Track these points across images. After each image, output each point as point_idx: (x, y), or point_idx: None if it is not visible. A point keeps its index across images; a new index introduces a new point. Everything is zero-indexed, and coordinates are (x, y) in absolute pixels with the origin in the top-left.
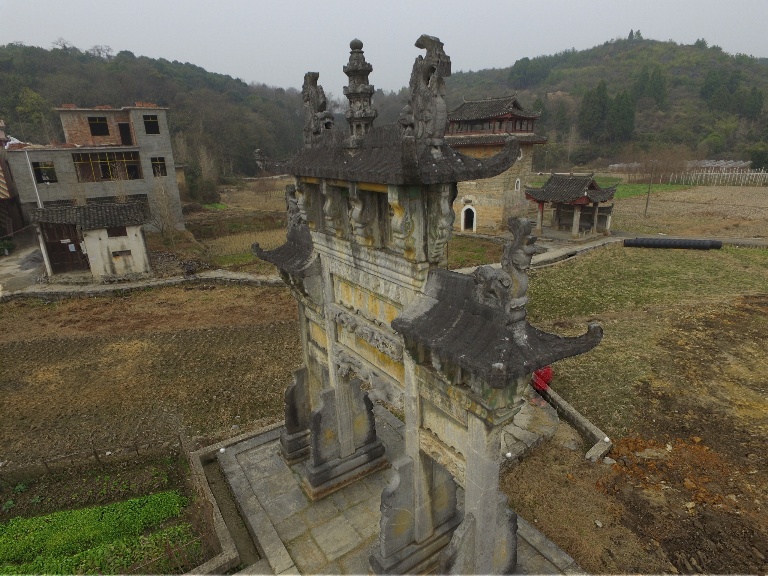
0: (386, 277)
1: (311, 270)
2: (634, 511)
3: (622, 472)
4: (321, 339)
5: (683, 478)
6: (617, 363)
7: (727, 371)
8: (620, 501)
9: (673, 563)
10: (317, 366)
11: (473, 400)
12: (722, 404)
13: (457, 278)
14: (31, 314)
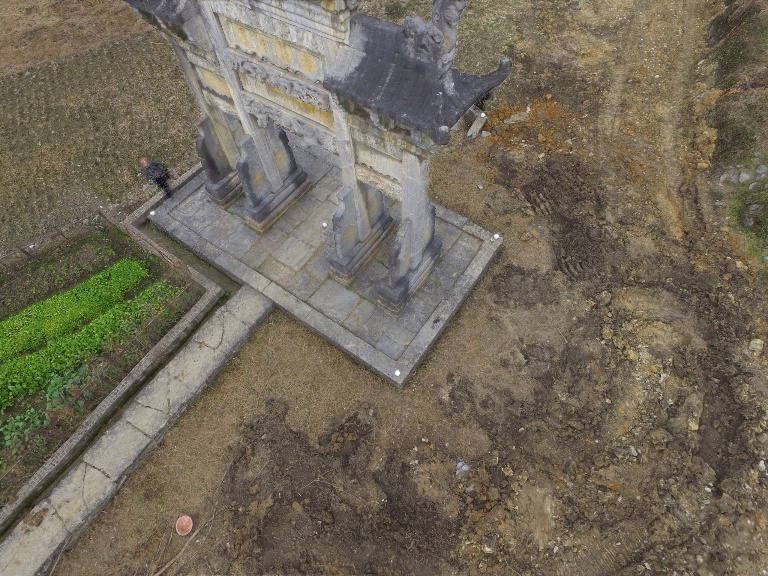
0: (298, 24)
1: (188, 11)
2: (503, 170)
3: (495, 141)
4: (219, 86)
5: (537, 134)
6: (487, 28)
7: (577, 18)
8: (494, 165)
9: (528, 200)
10: (218, 112)
11: (408, 142)
12: (570, 56)
13: (385, 30)
14: None
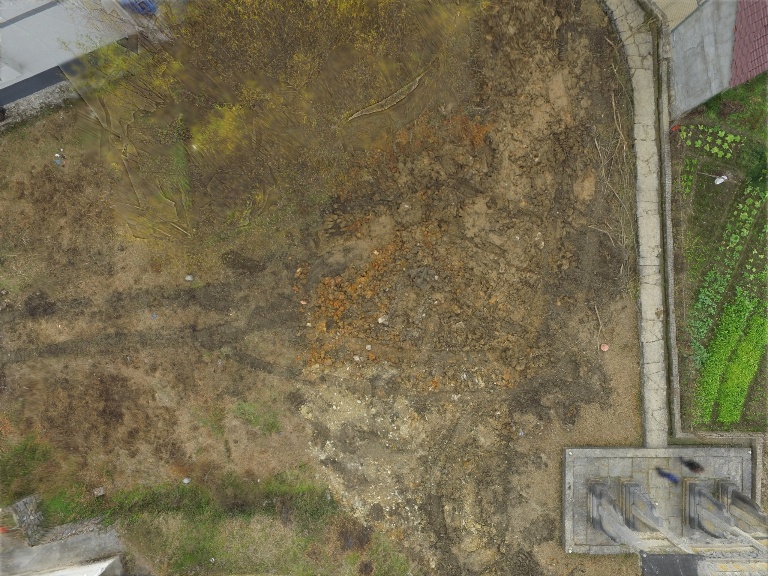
0: None
1: None
2: None
3: None
4: None
5: None
6: None
7: None
8: None
9: None
10: (764, 531)
11: None
12: None
13: None
14: None
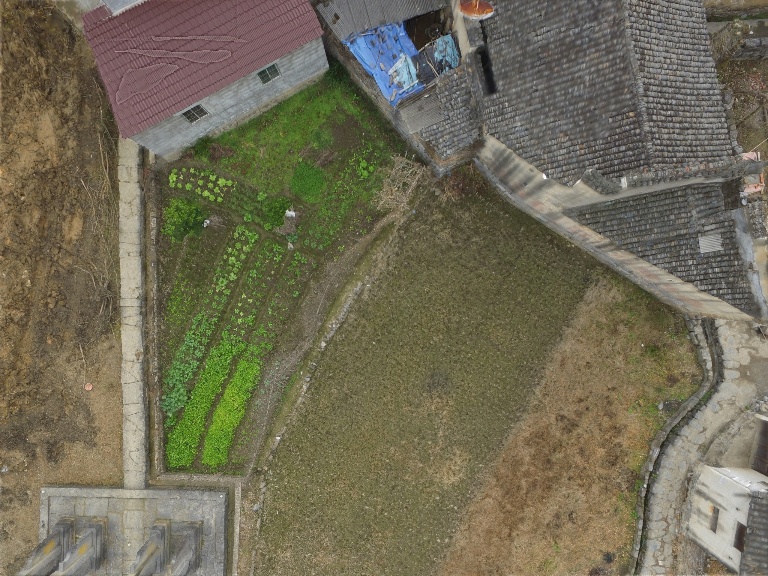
0: None
1: None
2: None
3: None
4: None
5: None
6: None
7: None
8: None
9: None
10: None
11: None
12: None
13: None
14: (629, 389)
